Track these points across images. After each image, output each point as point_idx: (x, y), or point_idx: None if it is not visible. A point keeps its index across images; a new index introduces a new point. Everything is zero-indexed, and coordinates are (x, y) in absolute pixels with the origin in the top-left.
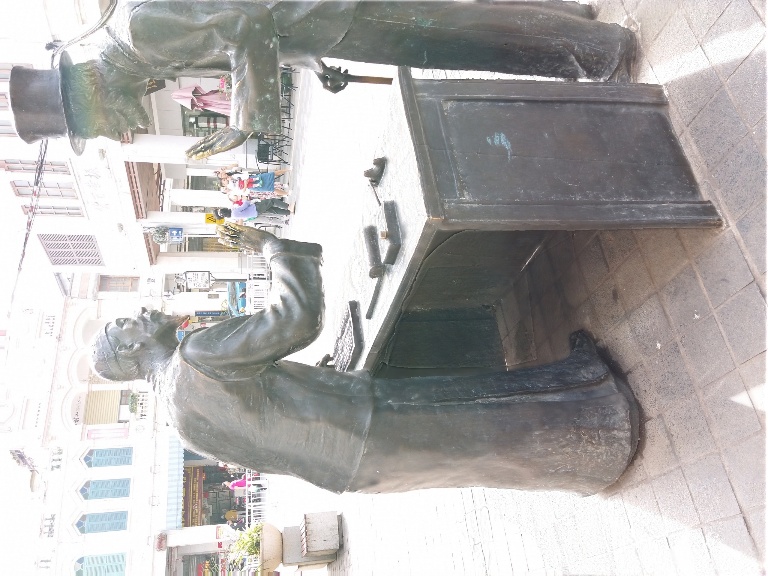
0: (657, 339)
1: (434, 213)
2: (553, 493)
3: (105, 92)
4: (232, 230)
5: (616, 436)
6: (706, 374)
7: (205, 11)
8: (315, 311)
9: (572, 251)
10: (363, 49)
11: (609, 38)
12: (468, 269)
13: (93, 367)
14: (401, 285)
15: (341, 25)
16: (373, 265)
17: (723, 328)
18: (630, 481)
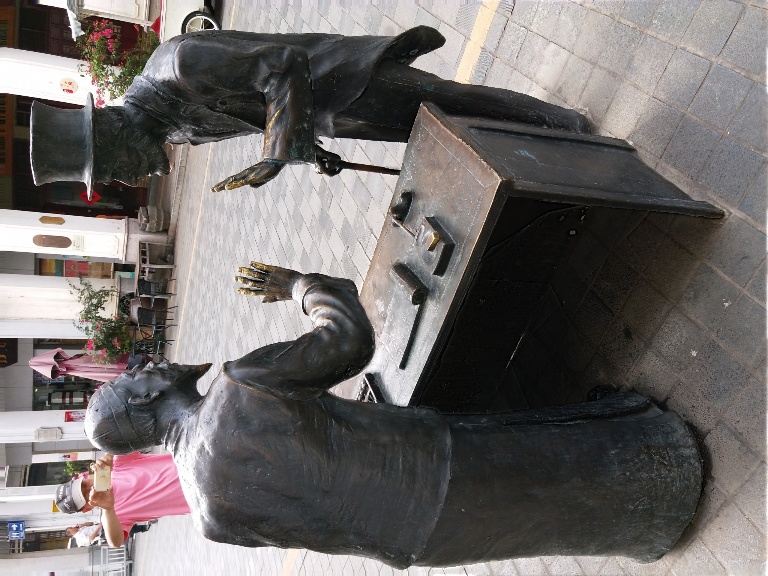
0: (690, 348)
1: (506, 176)
2: None
3: (131, 131)
4: (257, 272)
5: (684, 454)
6: (757, 351)
7: (251, 45)
8: (368, 329)
9: (565, 318)
10: (376, 109)
11: (569, 115)
12: (458, 367)
13: (90, 434)
14: (460, 286)
15: (360, 82)
16: (416, 288)
17: (760, 299)
18: (706, 514)
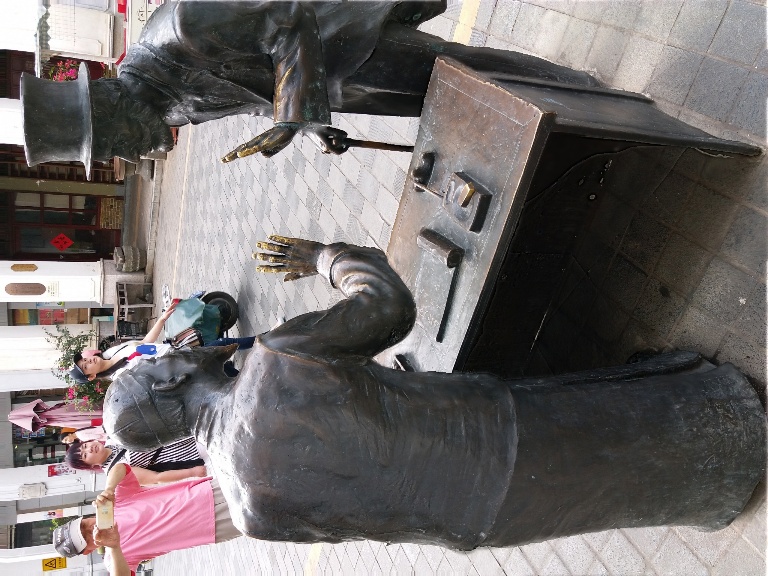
0: (738, 296)
1: (547, 109)
2: (670, 572)
3: (130, 101)
4: (278, 246)
5: (747, 406)
6: None
7: (255, 1)
8: (407, 292)
9: (592, 288)
10: (385, 73)
11: (579, 75)
12: (482, 351)
13: (111, 428)
14: (502, 238)
15: (368, 43)
16: (451, 249)
17: None
18: None
